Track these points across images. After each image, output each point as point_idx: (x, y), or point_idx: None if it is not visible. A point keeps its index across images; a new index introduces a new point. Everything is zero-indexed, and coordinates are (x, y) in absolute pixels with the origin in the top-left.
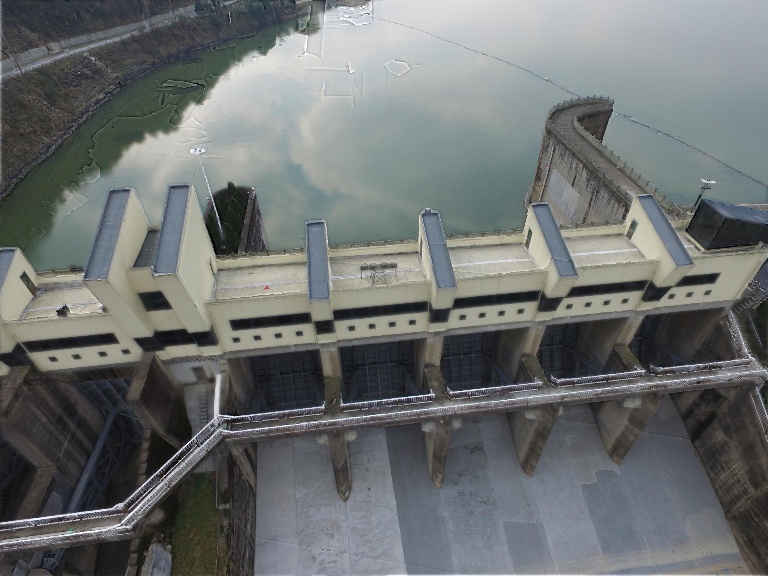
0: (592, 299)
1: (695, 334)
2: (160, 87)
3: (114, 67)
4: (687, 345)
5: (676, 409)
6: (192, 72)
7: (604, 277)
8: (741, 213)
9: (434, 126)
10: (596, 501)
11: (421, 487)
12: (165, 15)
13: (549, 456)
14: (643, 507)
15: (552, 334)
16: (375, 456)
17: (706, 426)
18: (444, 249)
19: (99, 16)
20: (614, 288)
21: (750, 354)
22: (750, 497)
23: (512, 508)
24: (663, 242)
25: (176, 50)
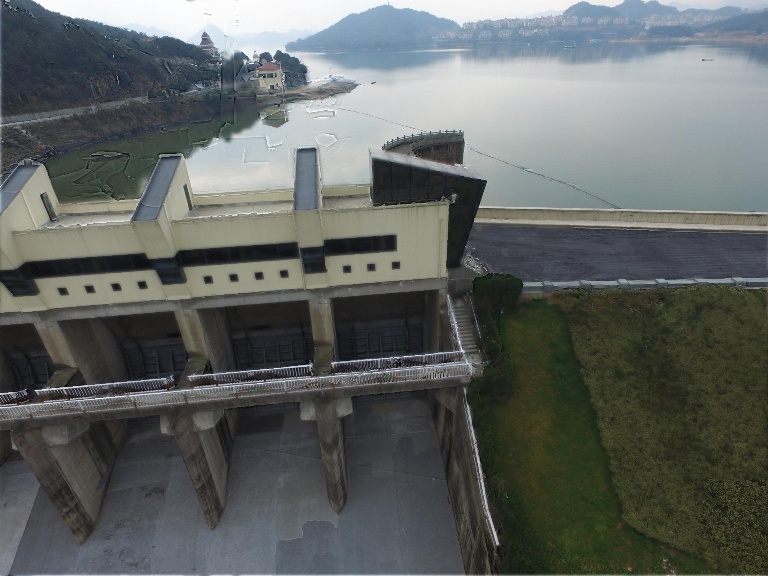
0: (235, 269)
1: (435, 335)
2: (86, 156)
3: (46, 140)
4: (434, 352)
5: (437, 441)
6: (140, 150)
7: (233, 236)
8: (409, 161)
9: (328, 179)
10: (291, 565)
11: (57, 542)
12: (120, 102)
13: (249, 501)
14: (354, 574)
15: (289, 346)
16: (17, 499)
17: (450, 457)
18: (13, 197)
19: (47, 99)
20: (257, 253)
21: (472, 350)
22: (473, 553)
23: (169, 573)
24: (295, 188)
25: (121, 129)
